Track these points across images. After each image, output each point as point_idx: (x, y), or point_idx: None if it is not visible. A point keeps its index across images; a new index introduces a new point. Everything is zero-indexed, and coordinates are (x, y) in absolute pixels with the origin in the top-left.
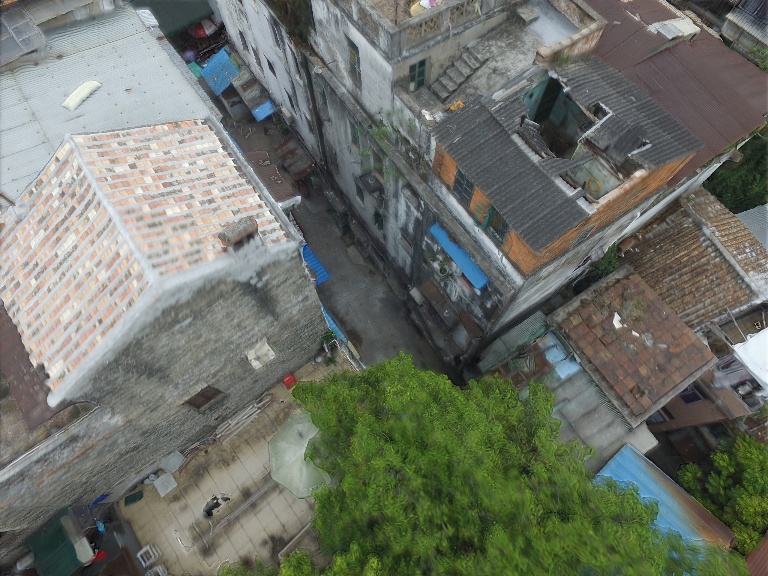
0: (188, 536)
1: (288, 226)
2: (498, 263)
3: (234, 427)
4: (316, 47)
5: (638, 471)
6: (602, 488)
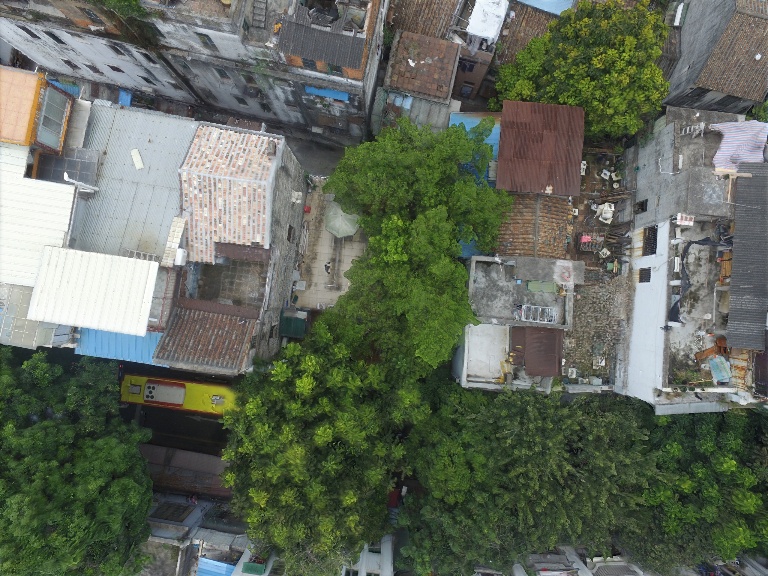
0: (328, 291)
1: (275, 136)
2: (347, 83)
3: (304, 245)
4: (168, 44)
5: (461, 120)
6: (439, 132)
